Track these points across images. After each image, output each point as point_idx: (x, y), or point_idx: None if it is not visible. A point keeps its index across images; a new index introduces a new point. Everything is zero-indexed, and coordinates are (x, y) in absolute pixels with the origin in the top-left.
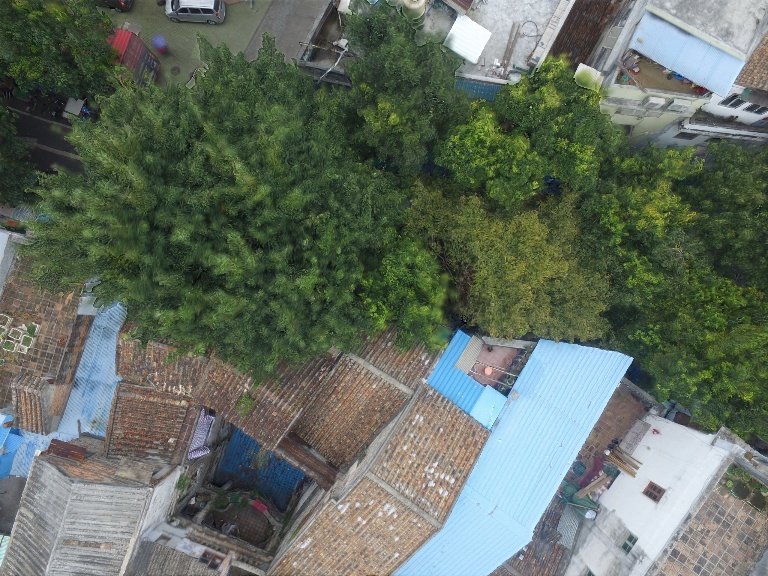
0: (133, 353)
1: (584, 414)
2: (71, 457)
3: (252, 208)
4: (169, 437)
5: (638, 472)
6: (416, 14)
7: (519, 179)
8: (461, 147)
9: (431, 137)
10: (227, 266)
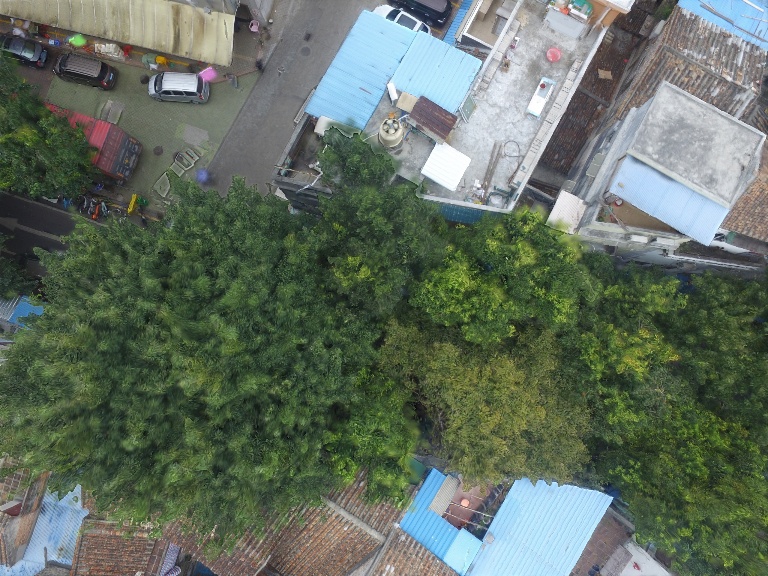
0: None
1: (561, 558)
2: None
3: None
4: (136, 570)
5: None
6: (393, 142)
7: (495, 325)
8: (435, 293)
9: (405, 280)
10: (178, 478)
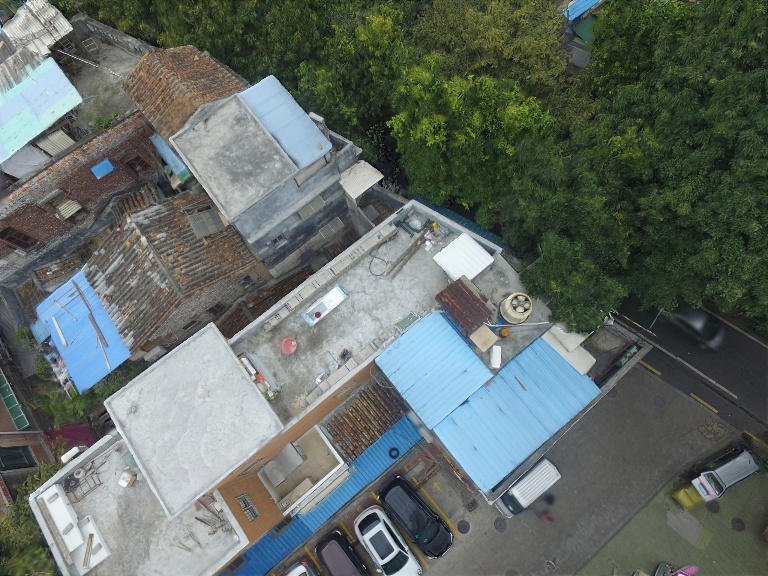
0: None
1: None
2: None
3: None
4: None
5: None
6: None
7: None
8: None
9: None
10: None
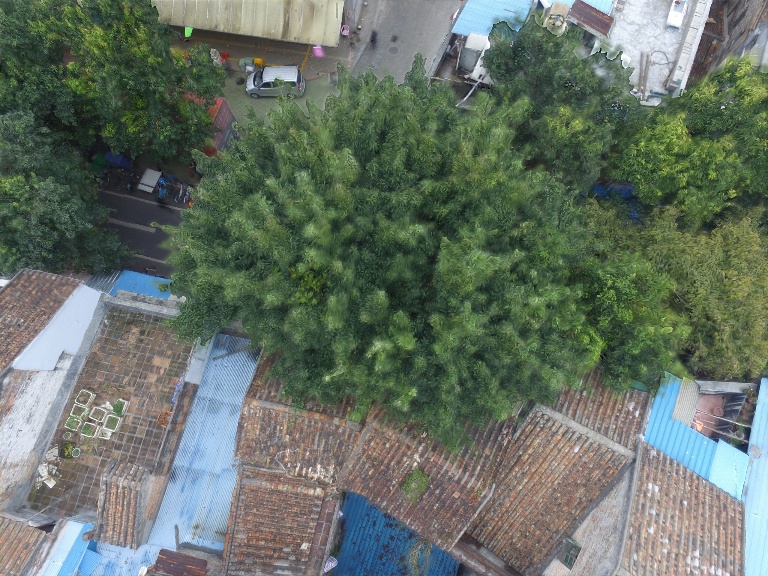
0: (260, 425)
1: None
2: (187, 575)
3: (461, 209)
4: (302, 541)
5: None
6: None
7: (716, 187)
8: (646, 155)
9: (608, 148)
10: (483, 259)
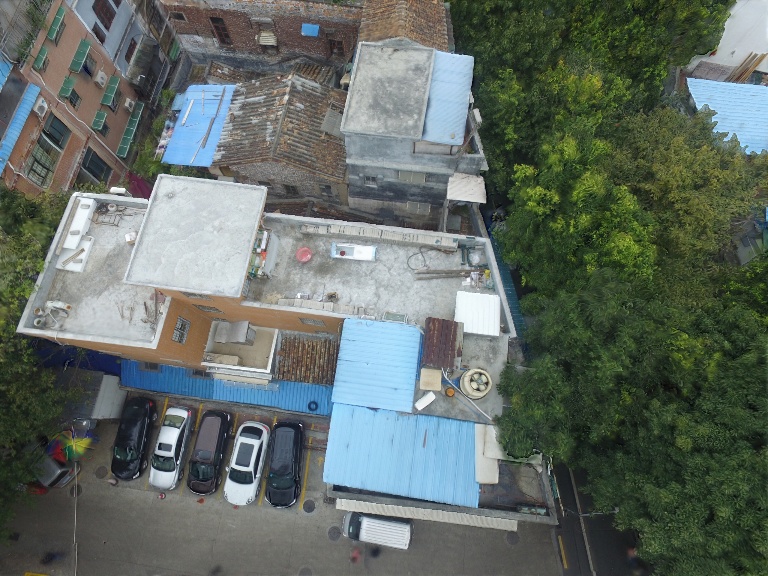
0: None
1: (764, 97)
2: None
3: None
4: None
5: (762, 53)
6: None
7: None
8: None
9: None
10: None
